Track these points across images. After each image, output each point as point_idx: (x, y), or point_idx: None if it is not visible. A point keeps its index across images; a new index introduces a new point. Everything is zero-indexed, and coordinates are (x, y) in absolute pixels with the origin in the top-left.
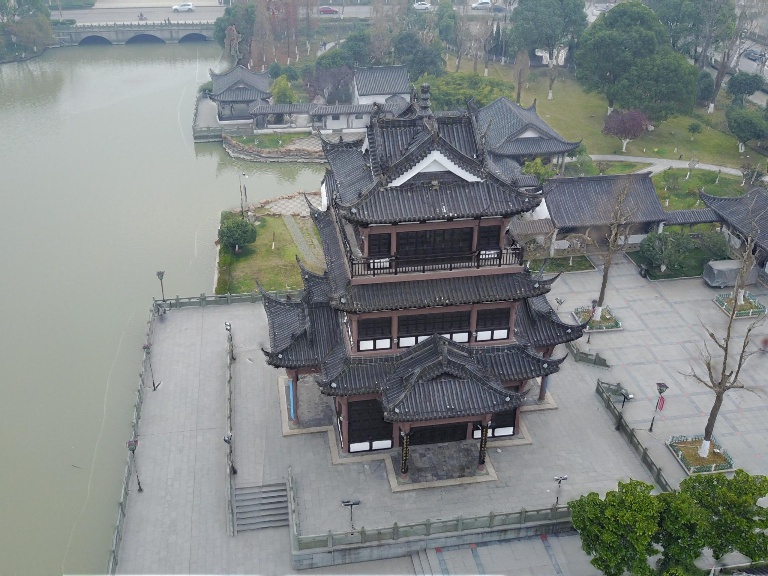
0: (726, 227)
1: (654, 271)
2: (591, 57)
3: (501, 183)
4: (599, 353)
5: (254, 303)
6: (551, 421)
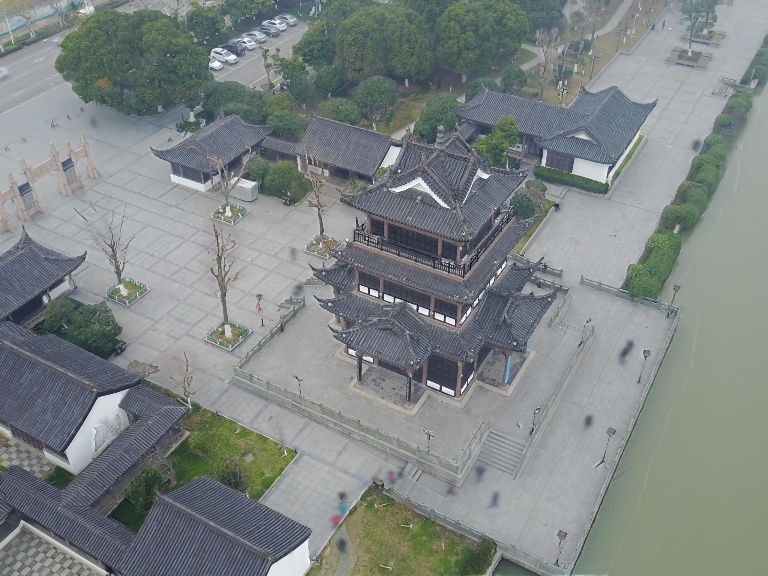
0: None
1: (108, 349)
2: None
3: None
4: (271, 316)
5: None
6: None
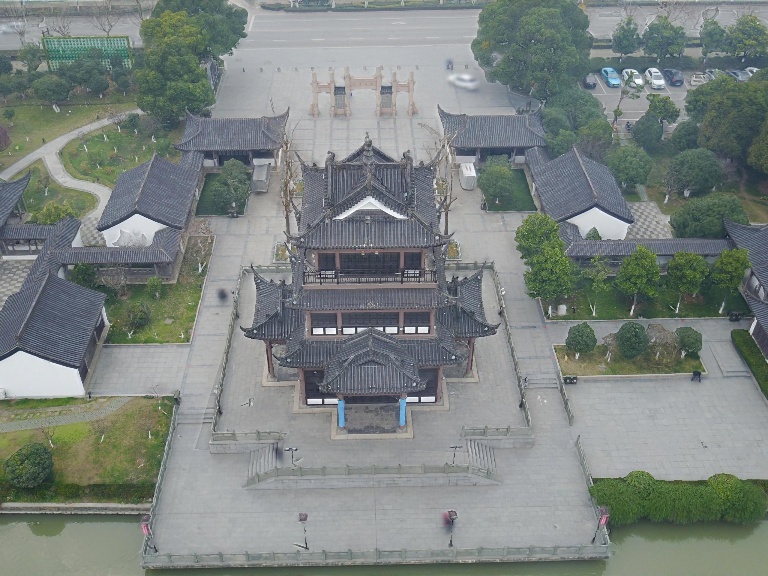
0: None
1: None
2: None
3: (417, 169)
4: None
5: (167, 468)
6: None
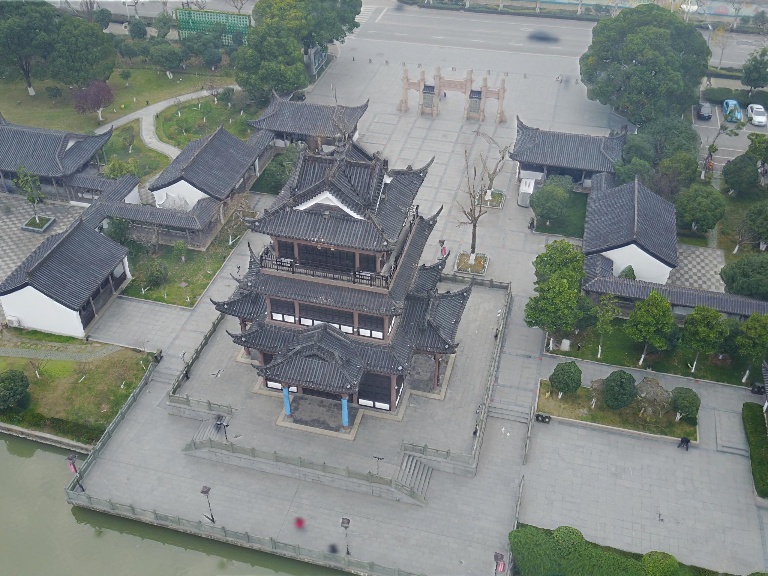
0: (276, 137)
1: None
2: (4, 50)
3: (402, 173)
4: None
5: (125, 418)
6: None
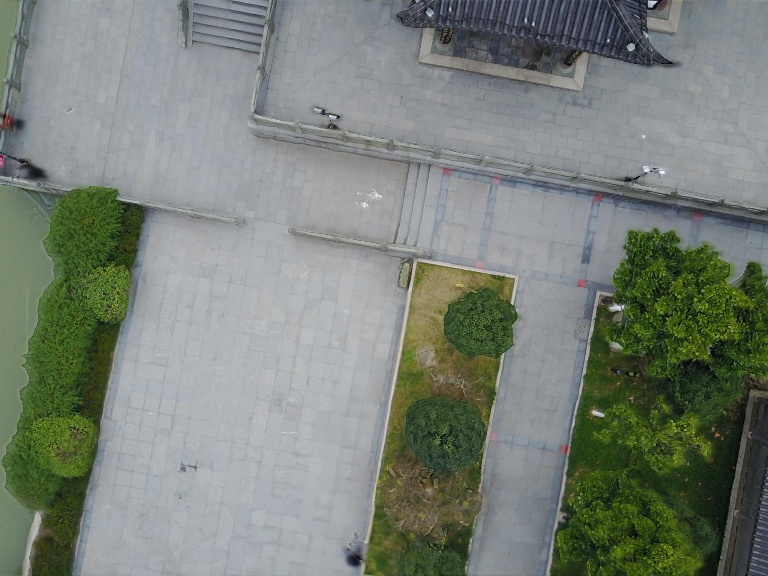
0: None
1: None
2: None
3: None
4: None
5: None
6: None
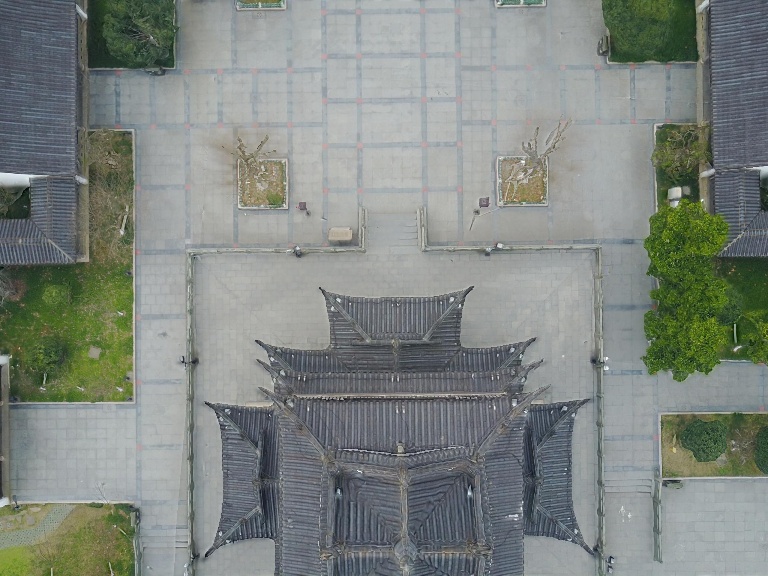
0: None
1: None
2: None
3: None
4: (332, 210)
5: None
6: (465, 319)
